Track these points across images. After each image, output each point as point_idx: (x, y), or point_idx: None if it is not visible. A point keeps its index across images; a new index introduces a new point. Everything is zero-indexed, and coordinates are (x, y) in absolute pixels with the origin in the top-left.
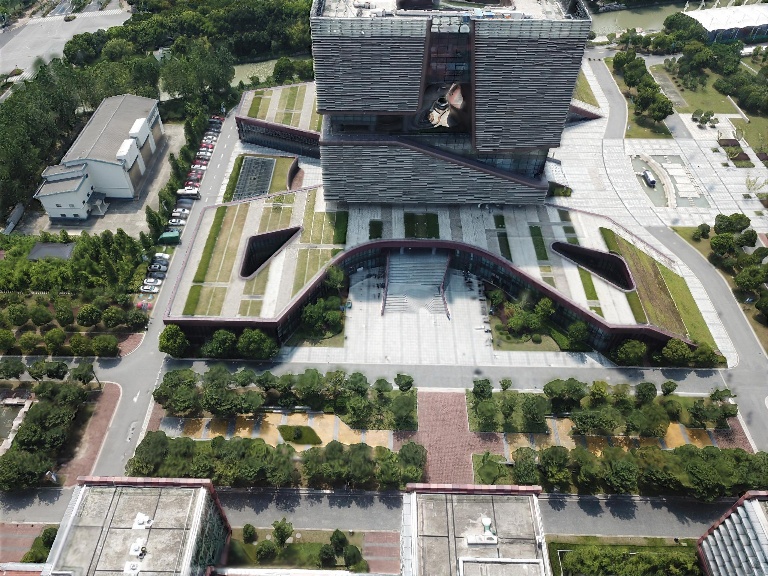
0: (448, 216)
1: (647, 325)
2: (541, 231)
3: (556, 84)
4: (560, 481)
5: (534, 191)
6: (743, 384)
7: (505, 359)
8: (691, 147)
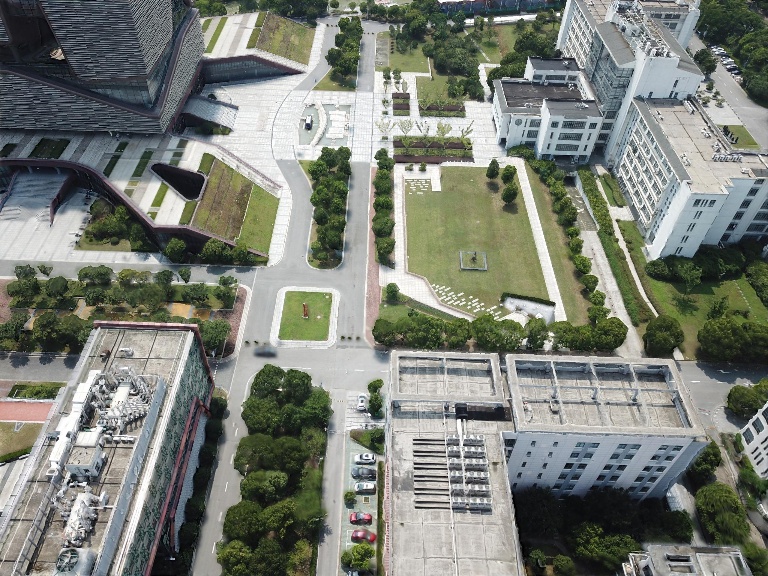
0: (79, 142)
1: (185, 225)
2: (152, 155)
3: (116, 18)
4: (40, 338)
5: (148, 120)
6: (270, 278)
7: (79, 256)
8: (366, 98)
